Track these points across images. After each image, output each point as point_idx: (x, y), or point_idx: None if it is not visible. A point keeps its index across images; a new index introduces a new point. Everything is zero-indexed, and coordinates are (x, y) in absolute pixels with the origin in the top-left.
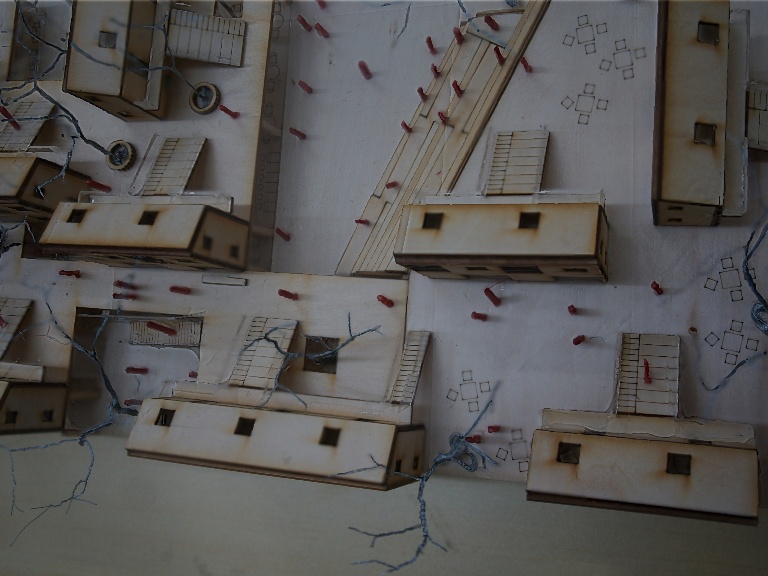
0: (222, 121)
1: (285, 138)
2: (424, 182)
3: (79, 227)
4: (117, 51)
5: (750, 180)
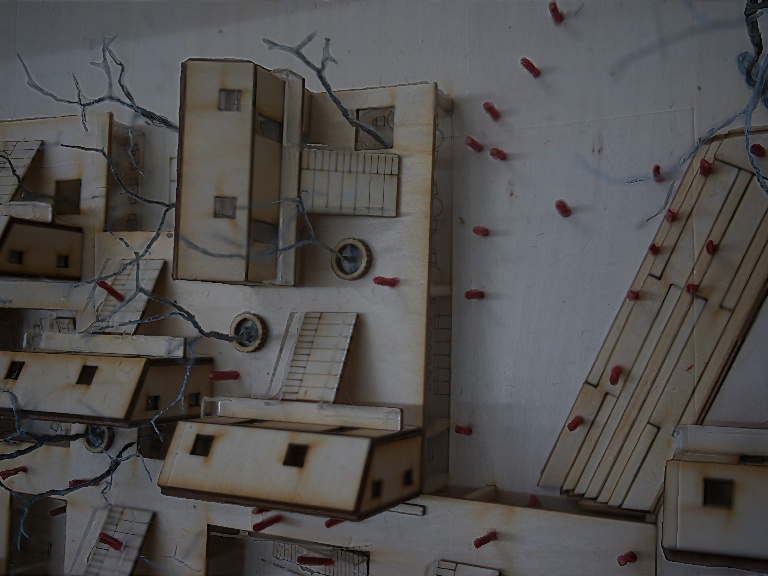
0: (376, 289)
1: (456, 296)
2: (668, 381)
3: (206, 463)
4: (238, 221)
5: None
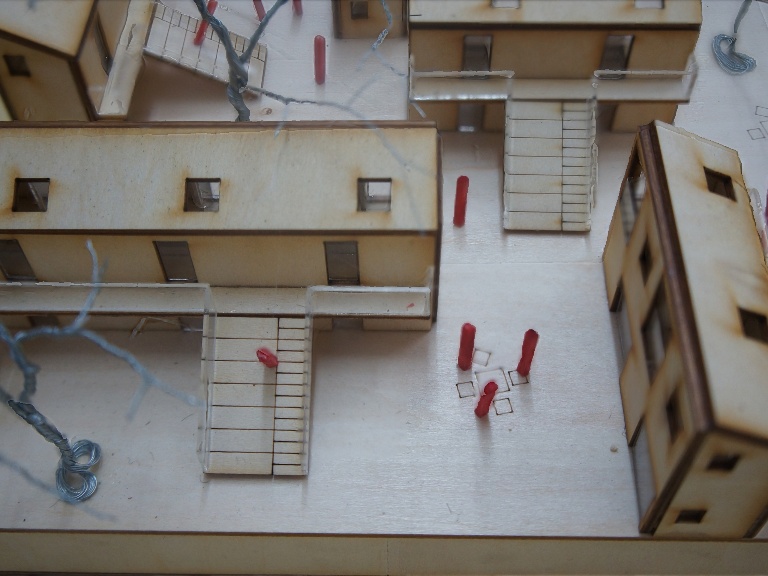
0: None
1: None
2: None
3: None
4: None
5: (473, 159)
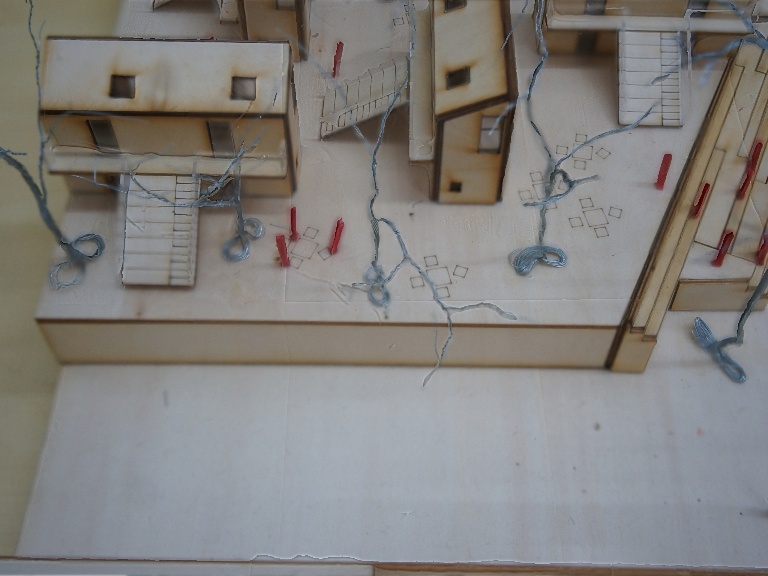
0: None
1: None
2: None
3: None
4: None
5: None
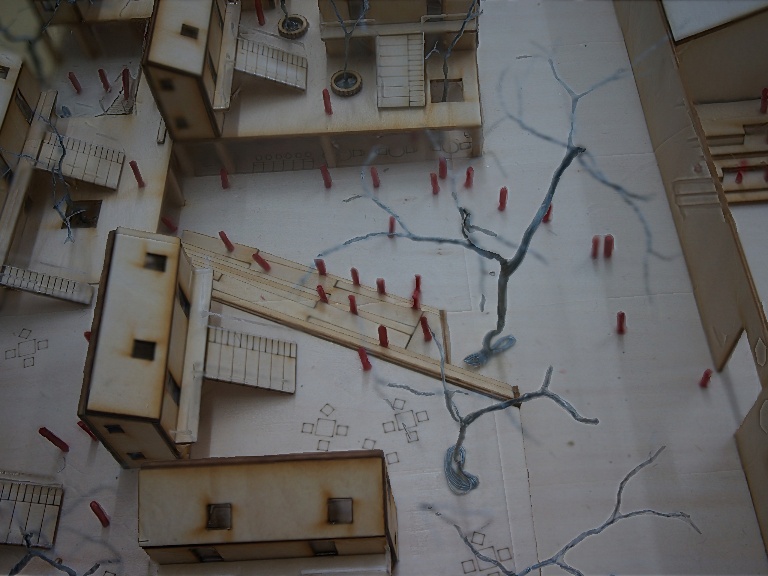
0: None
1: None
2: None
3: None
4: None
5: None
